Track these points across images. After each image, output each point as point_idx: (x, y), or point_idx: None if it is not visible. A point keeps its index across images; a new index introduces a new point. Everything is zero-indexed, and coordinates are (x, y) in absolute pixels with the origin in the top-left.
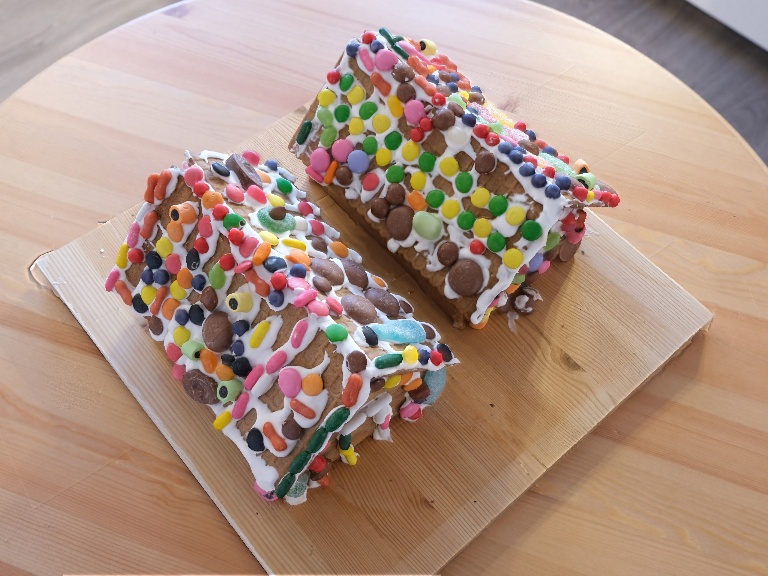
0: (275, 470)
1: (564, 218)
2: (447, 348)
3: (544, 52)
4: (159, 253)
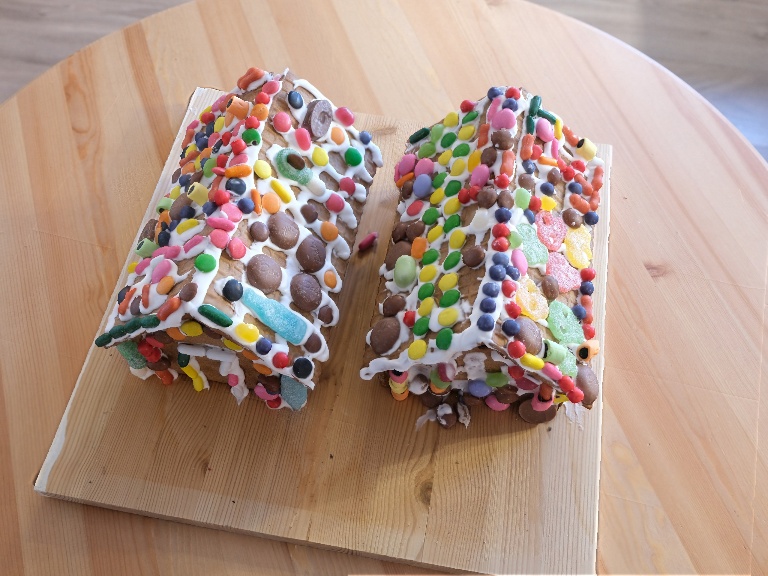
0: (113, 325)
1: (510, 366)
2: (307, 366)
3: (749, 255)
4: (214, 126)
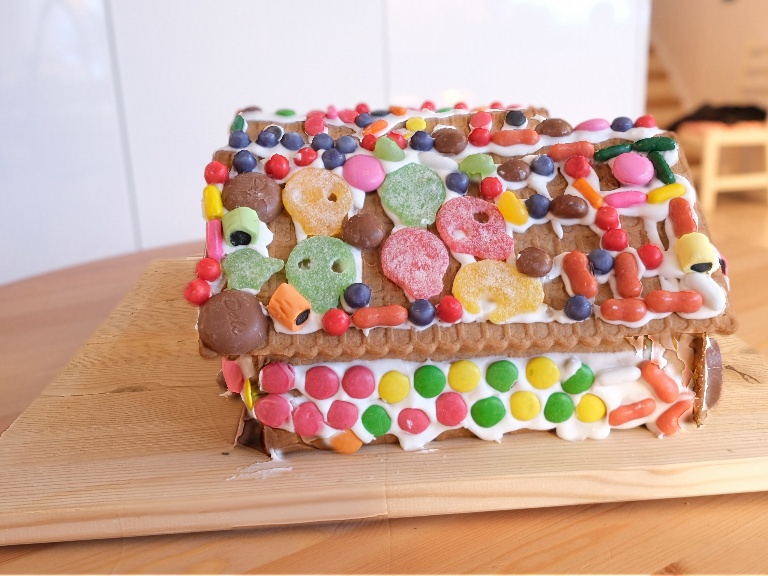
0: None
1: None
2: None
3: None
4: None
